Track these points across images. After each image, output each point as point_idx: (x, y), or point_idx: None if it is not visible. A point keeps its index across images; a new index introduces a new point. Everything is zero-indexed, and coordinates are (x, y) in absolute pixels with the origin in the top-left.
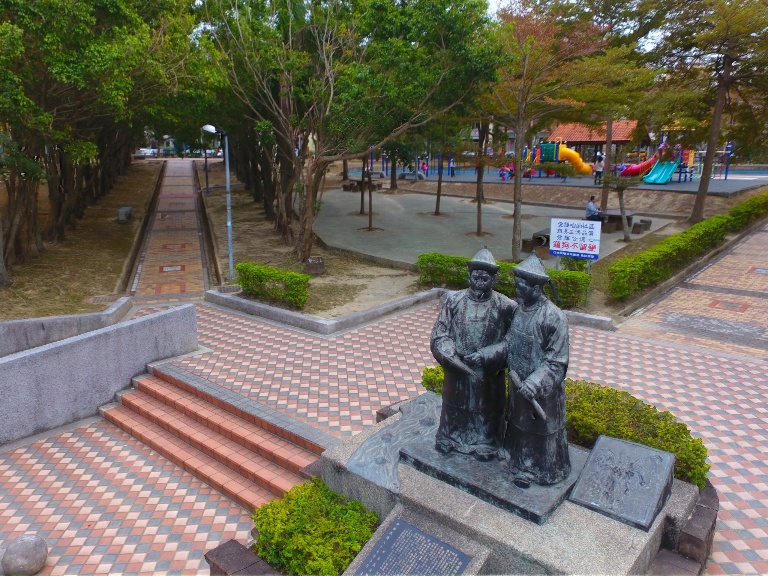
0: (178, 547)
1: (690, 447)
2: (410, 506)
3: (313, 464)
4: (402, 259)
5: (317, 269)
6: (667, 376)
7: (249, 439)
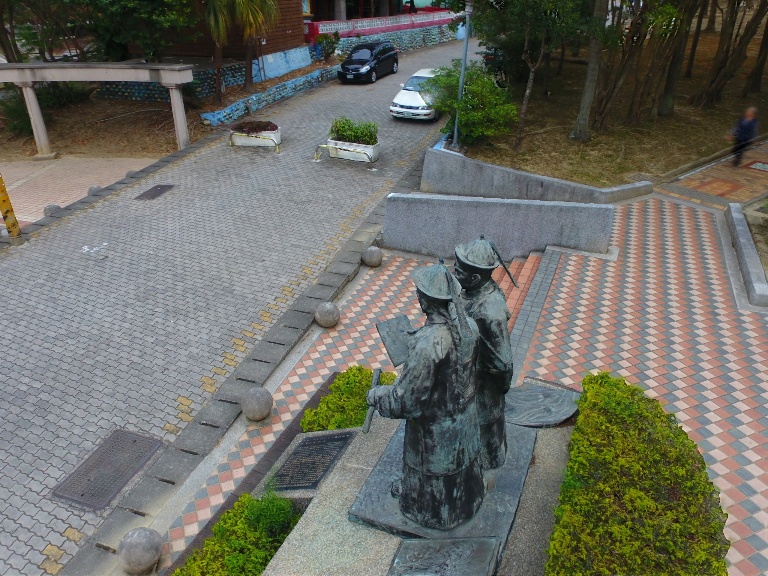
0: None
1: None
2: None
3: None
4: None
5: None
6: None
7: None
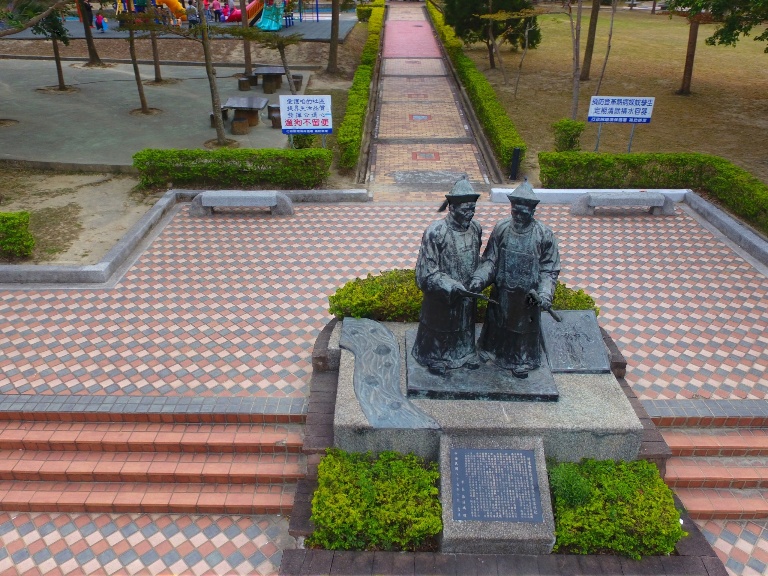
0: None
1: (582, 299)
2: (456, 434)
3: (308, 437)
4: (91, 160)
5: None
6: None
7: (163, 441)
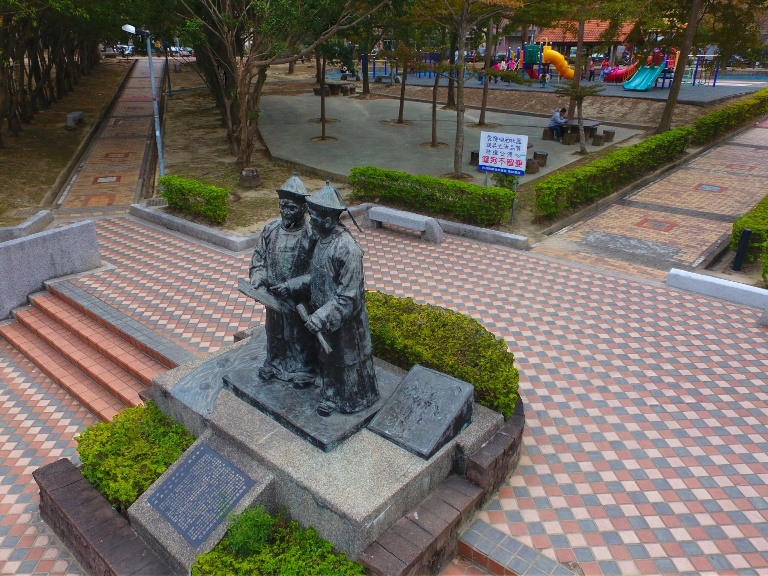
0: (30, 462)
1: (502, 377)
2: (217, 431)
3: None
4: (343, 172)
5: (251, 182)
6: (558, 298)
7: (120, 359)
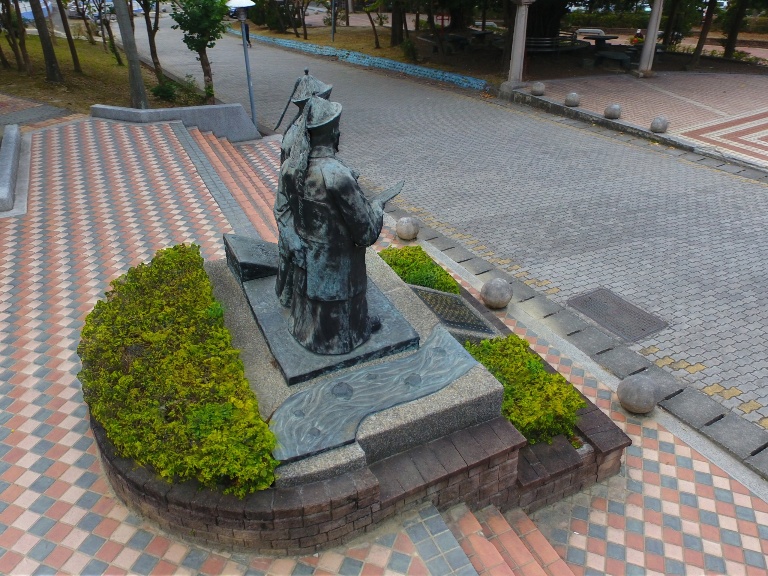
0: (685, 570)
1: (179, 251)
2: None
3: (507, 444)
4: None
5: None
6: None
7: None
